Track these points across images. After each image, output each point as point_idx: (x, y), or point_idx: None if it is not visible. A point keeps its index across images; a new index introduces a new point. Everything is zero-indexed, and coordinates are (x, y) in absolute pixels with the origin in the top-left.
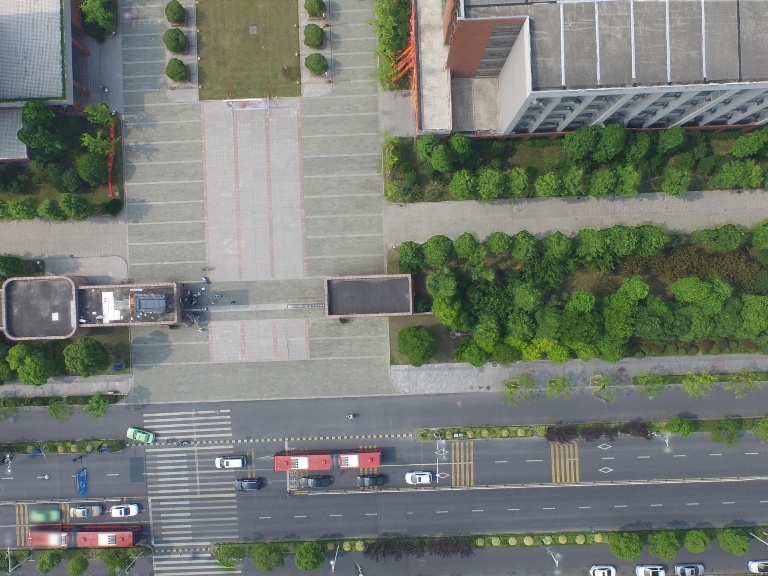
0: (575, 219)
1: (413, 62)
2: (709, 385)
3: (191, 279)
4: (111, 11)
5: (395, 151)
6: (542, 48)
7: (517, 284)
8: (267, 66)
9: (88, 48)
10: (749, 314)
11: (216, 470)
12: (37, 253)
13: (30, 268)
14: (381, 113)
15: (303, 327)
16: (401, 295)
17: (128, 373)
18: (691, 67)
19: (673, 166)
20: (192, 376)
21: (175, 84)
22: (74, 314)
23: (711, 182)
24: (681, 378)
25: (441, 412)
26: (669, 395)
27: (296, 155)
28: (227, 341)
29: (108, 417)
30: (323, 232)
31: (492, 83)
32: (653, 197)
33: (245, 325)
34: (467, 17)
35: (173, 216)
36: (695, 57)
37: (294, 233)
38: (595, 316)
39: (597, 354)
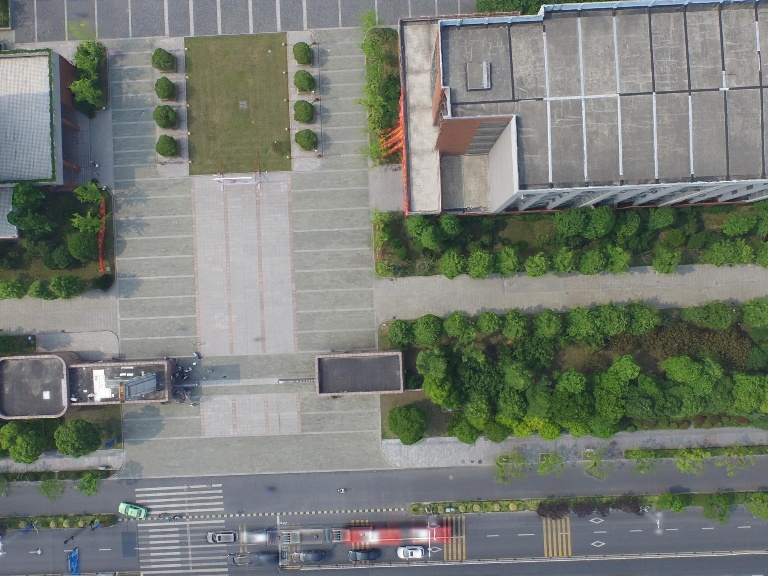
0: (566, 293)
1: (402, 143)
2: (700, 463)
3: (182, 354)
4: (101, 87)
5: (385, 228)
6: (529, 145)
7: (508, 362)
8: (257, 141)
9: (78, 123)
10: (740, 393)
11: (208, 545)
12: (28, 328)
13: (22, 343)
14: (371, 187)
15: (294, 402)
16: (392, 372)
17: (120, 448)
18: (678, 164)
19: (664, 241)
20: (184, 451)
21: (165, 159)
22: (65, 393)
23: (702, 257)
24: (673, 452)
25: (433, 486)
26: (661, 469)
27: (287, 229)
28: (218, 416)
29: (100, 492)
30: (314, 306)
31: (482, 160)
32: (644, 271)
33: (236, 400)
34: (454, 114)
35: (164, 291)
36: (682, 154)
37: (285, 308)
38: (585, 398)
39: (588, 432)
